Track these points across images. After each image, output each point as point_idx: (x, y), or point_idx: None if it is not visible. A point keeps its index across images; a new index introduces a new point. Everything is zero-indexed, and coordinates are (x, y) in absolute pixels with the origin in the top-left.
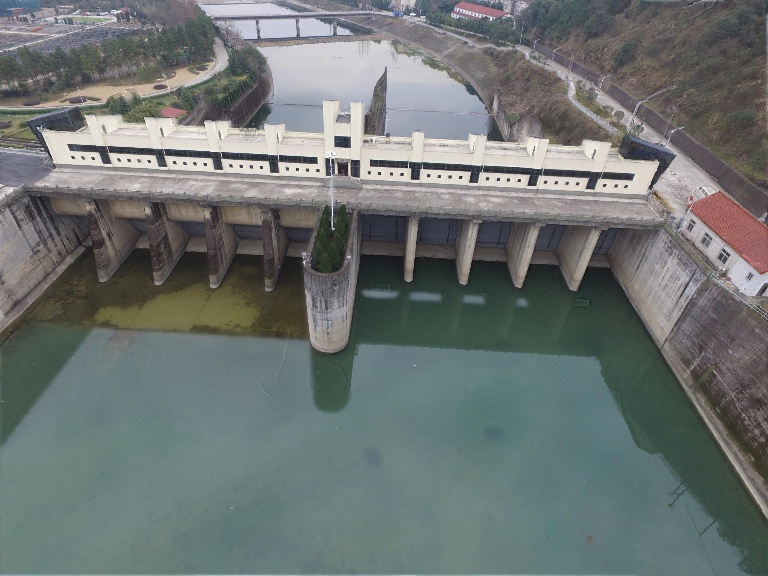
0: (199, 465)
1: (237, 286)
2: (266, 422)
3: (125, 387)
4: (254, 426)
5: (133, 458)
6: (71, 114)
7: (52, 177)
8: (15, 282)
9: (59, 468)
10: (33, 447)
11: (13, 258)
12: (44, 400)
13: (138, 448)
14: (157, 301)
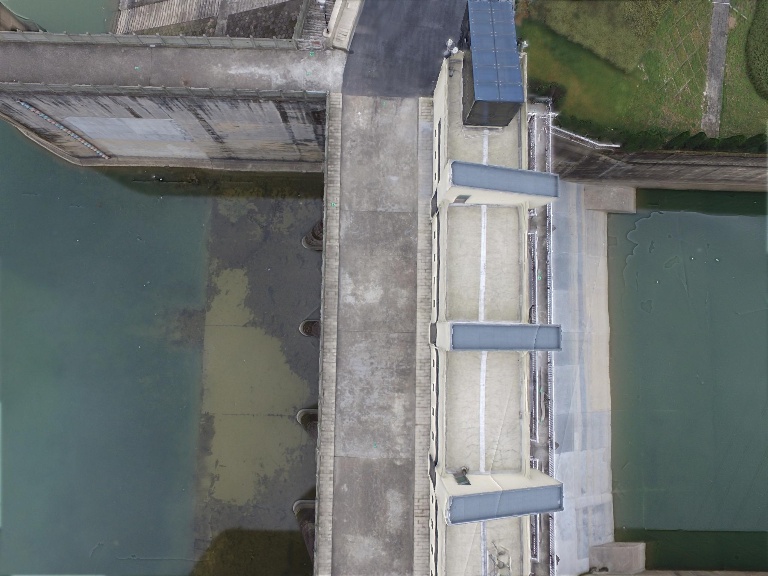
0: (3, 493)
1: (306, 452)
2: (56, 557)
3: (108, 366)
4: (49, 545)
5: (13, 418)
6: (488, 103)
7: (394, 112)
8: (244, 147)
9: (1, 347)
10: (26, 306)
11: (254, 134)
12: (86, 283)
13: (24, 418)
14: (264, 342)
